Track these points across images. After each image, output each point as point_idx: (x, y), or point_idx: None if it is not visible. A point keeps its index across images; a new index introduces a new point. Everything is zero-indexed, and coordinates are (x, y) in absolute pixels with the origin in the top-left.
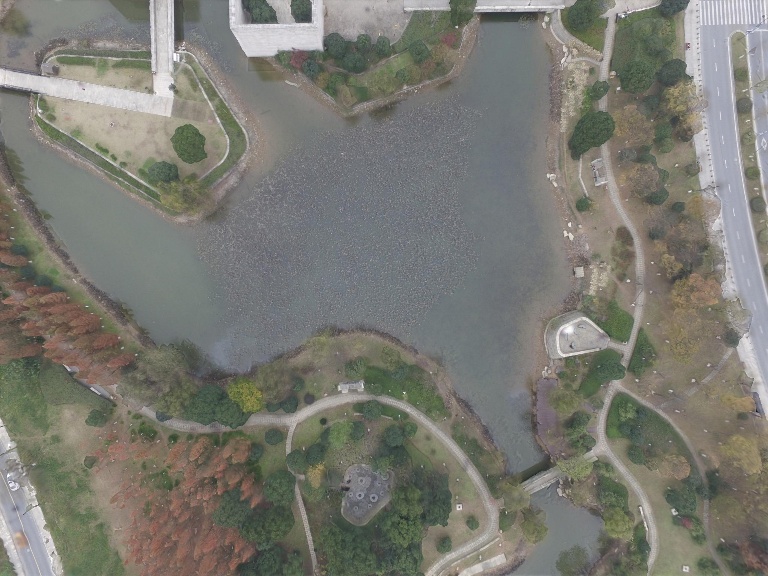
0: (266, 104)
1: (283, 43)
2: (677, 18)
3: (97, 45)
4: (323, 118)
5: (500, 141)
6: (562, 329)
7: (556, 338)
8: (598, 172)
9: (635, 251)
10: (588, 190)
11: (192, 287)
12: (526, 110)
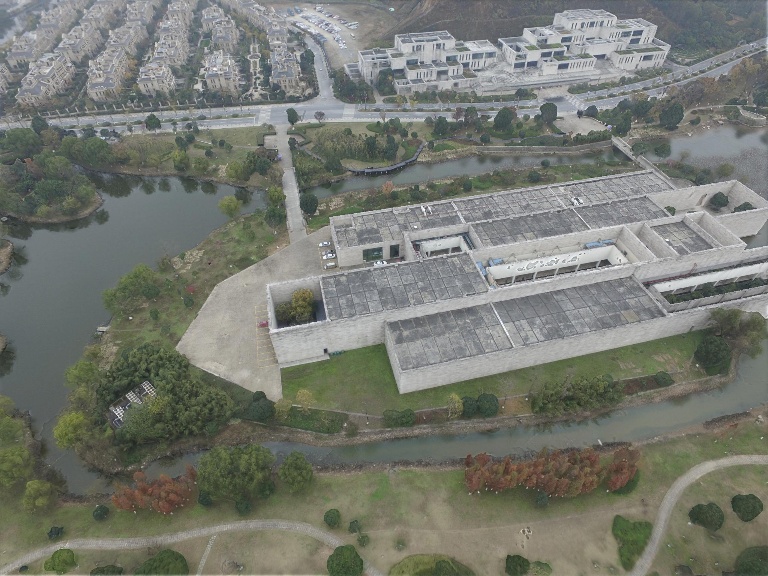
0: None
1: None
2: None
3: None
4: None
5: None
6: (755, 119)
7: (761, 119)
8: None
9: None
10: None
11: None
12: None
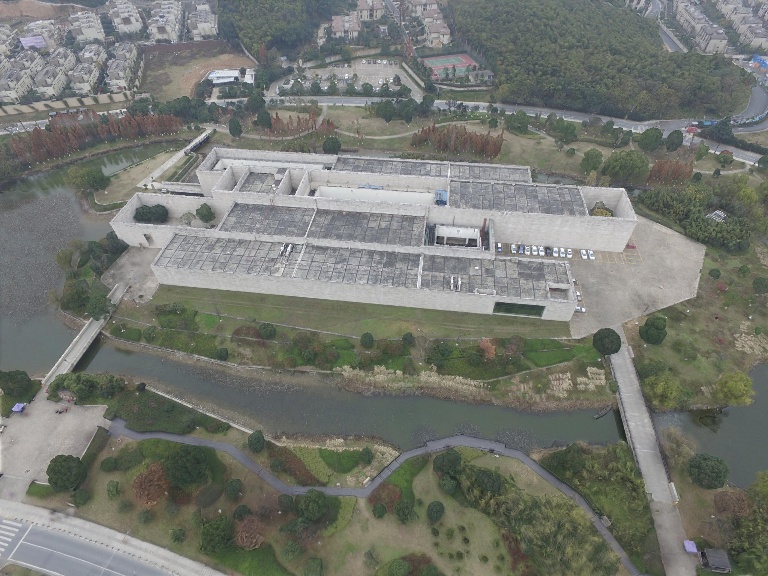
0: None
1: None
2: None
3: (195, 170)
4: None
5: None
6: None
7: None
8: None
9: None
10: None
11: None
12: None
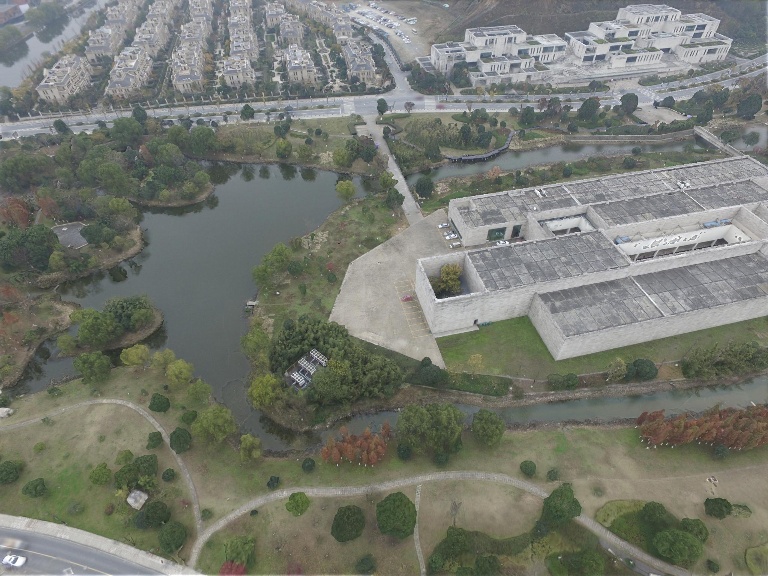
0: None
1: None
2: None
3: None
4: None
5: None
6: None
7: None
8: None
9: None
10: None
11: None
12: None
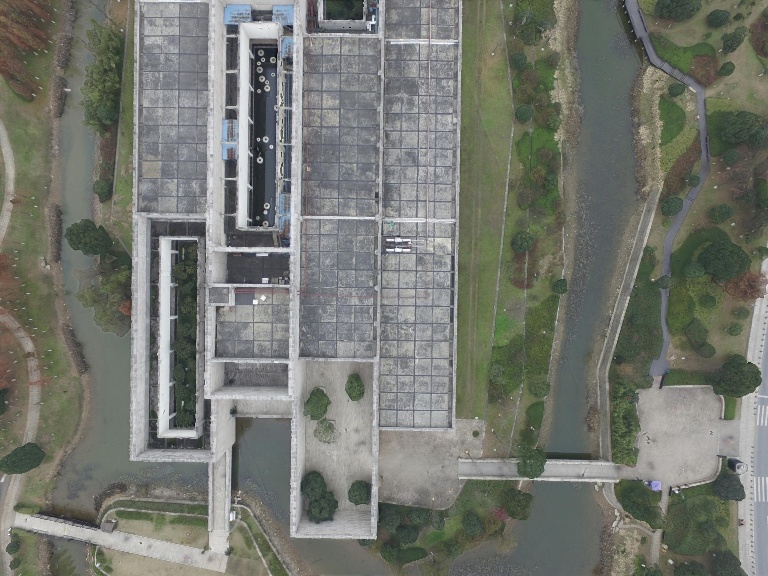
0: (318, 552)
1: None
2: None
3: (155, 493)
4: (374, 569)
5: None
6: None
7: None
8: None
9: None
10: None
11: None
12: (576, 568)
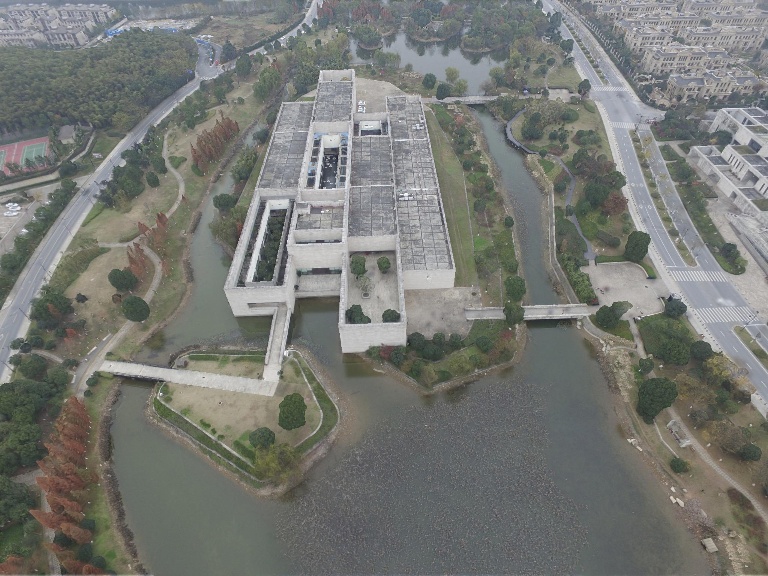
0: (356, 387)
1: (375, 339)
2: (682, 319)
3: (223, 348)
4: (407, 396)
5: (571, 411)
6: None
7: None
8: (677, 434)
9: (760, 516)
10: (676, 452)
11: (261, 575)
12: (586, 386)
